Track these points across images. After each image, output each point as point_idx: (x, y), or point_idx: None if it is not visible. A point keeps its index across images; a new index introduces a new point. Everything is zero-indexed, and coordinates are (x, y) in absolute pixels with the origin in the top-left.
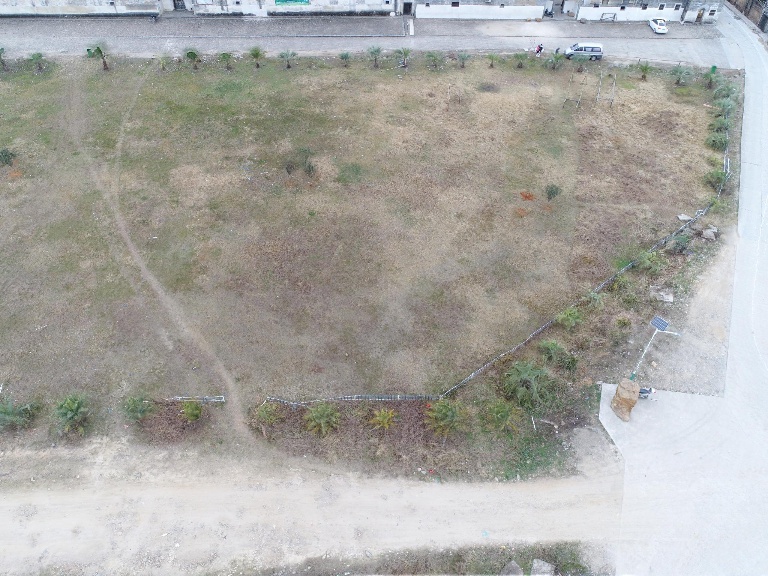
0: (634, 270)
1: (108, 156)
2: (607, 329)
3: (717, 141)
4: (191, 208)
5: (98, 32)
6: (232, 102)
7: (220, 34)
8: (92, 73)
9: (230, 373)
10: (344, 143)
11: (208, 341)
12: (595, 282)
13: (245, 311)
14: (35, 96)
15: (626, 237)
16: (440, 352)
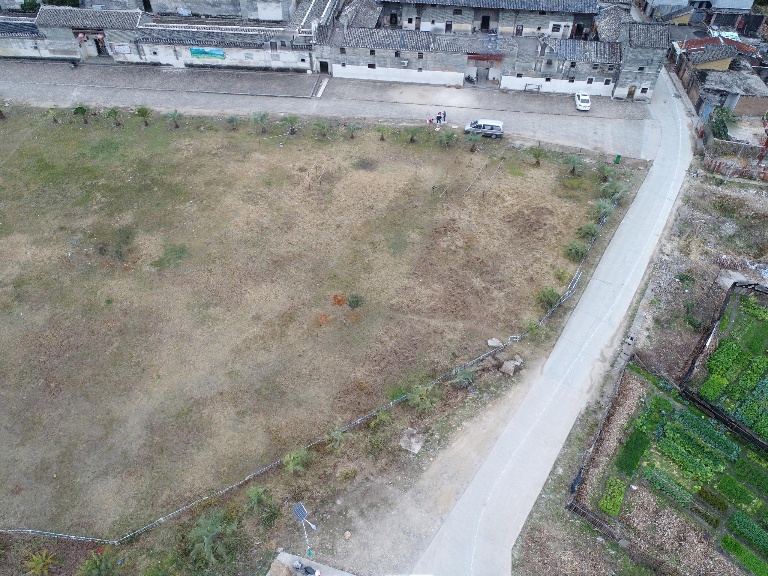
0: (407, 404)
1: None
2: (331, 479)
3: (573, 251)
4: None
5: (16, 76)
6: (101, 164)
7: (129, 85)
8: None
9: None
10: (185, 220)
11: None
12: (357, 415)
13: None
14: None
15: (419, 361)
16: (150, 484)
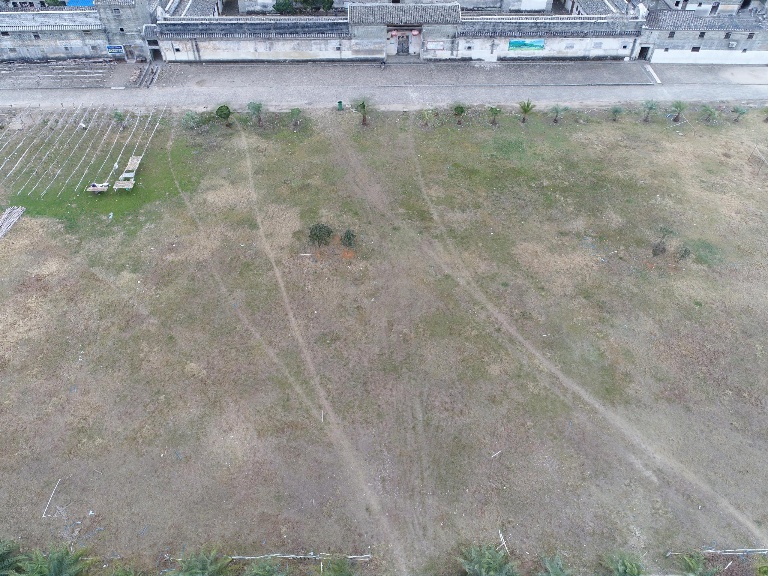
0: None
1: (433, 232)
2: None
3: None
4: (563, 297)
5: (330, 80)
6: (523, 164)
7: (460, 82)
8: (352, 129)
9: (744, 514)
10: (674, 215)
11: (692, 471)
12: None
13: (708, 431)
14: (309, 157)
15: None
16: None
